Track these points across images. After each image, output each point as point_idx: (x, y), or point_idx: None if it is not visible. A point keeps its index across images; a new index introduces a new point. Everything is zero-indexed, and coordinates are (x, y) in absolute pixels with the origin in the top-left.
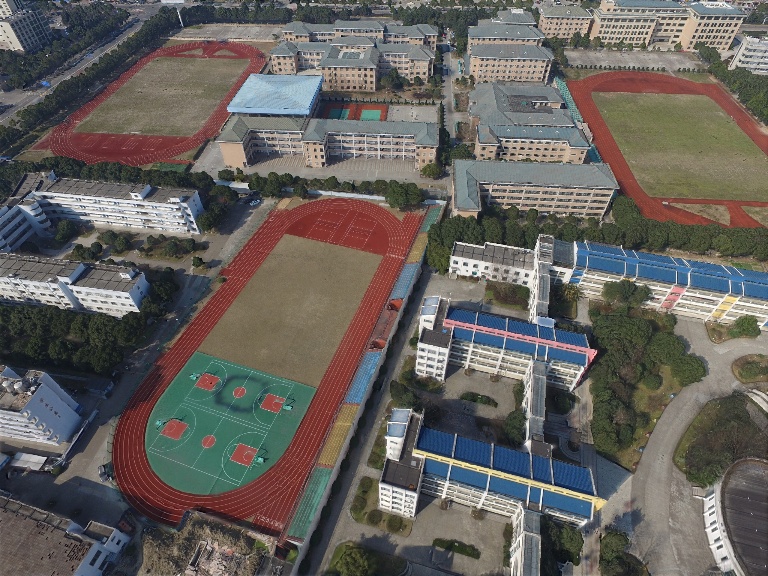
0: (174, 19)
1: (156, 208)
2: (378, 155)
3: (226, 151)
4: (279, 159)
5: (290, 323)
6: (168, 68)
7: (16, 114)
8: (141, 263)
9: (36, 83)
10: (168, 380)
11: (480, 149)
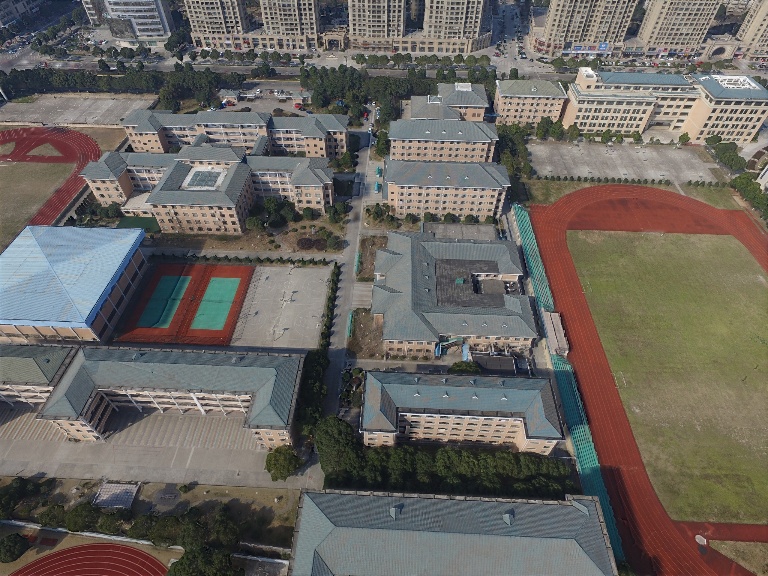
0: None
1: None
2: (201, 410)
3: None
4: (28, 417)
5: None
6: None
7: None
8: None
9: None
10: None
11: (365, 433)
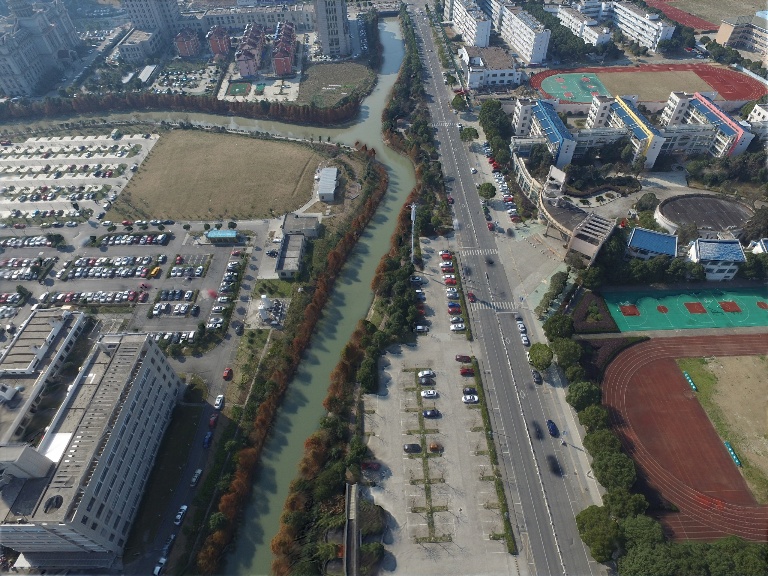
0: None
1: (649, 28)
2: None
3: (722, 30)
4: (750, 52)
5: (639, 87)
6: None
7: None
8: (617, 48)
9: None
10: (575, 72)
11: None
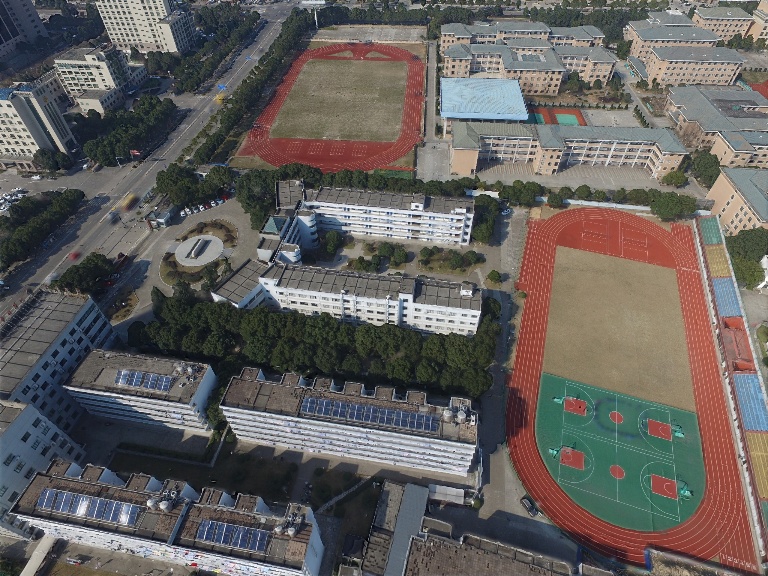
0: (311, 20)
1: (433, 219)
2: (606, 162)
3: (458, 158)
4: (501, 166)
5: (623, 342)
6: (328, 71)
7: (200, 118)
8: None
9: (201, 86)
10: (532, 404)
11: (733, 156)
